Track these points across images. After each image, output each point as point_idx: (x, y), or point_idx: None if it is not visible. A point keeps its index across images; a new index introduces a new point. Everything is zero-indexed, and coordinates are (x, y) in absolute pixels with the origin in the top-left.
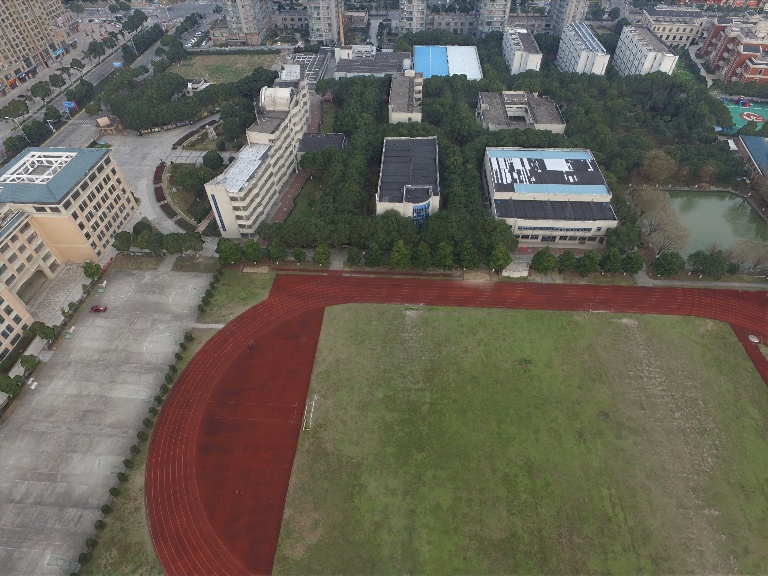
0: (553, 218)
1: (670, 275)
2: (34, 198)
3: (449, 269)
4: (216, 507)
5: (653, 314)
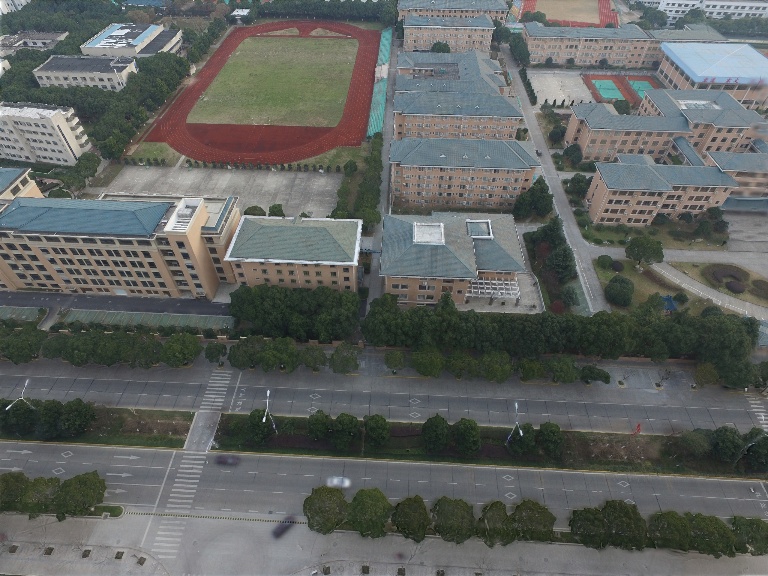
0: (166, 43)
1: (218, 36)
2: (5, 182)
3: (181, 82)
4: (303, 142)
5: (237, 48)
